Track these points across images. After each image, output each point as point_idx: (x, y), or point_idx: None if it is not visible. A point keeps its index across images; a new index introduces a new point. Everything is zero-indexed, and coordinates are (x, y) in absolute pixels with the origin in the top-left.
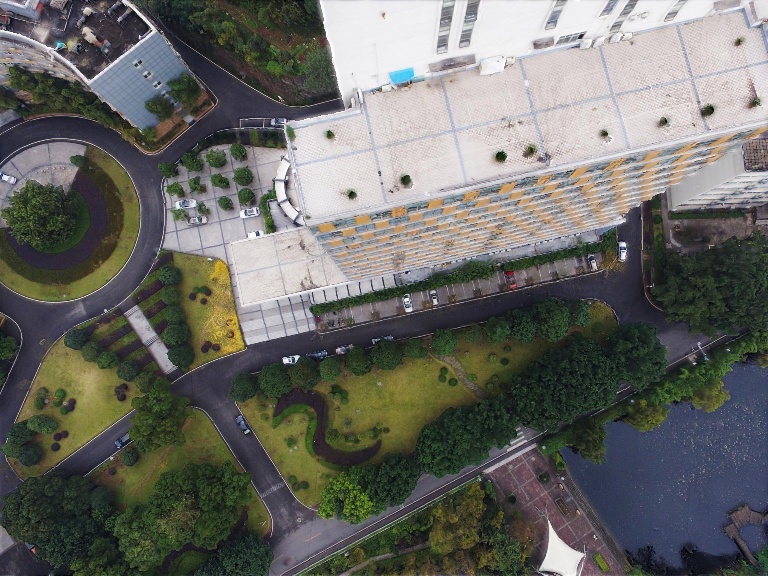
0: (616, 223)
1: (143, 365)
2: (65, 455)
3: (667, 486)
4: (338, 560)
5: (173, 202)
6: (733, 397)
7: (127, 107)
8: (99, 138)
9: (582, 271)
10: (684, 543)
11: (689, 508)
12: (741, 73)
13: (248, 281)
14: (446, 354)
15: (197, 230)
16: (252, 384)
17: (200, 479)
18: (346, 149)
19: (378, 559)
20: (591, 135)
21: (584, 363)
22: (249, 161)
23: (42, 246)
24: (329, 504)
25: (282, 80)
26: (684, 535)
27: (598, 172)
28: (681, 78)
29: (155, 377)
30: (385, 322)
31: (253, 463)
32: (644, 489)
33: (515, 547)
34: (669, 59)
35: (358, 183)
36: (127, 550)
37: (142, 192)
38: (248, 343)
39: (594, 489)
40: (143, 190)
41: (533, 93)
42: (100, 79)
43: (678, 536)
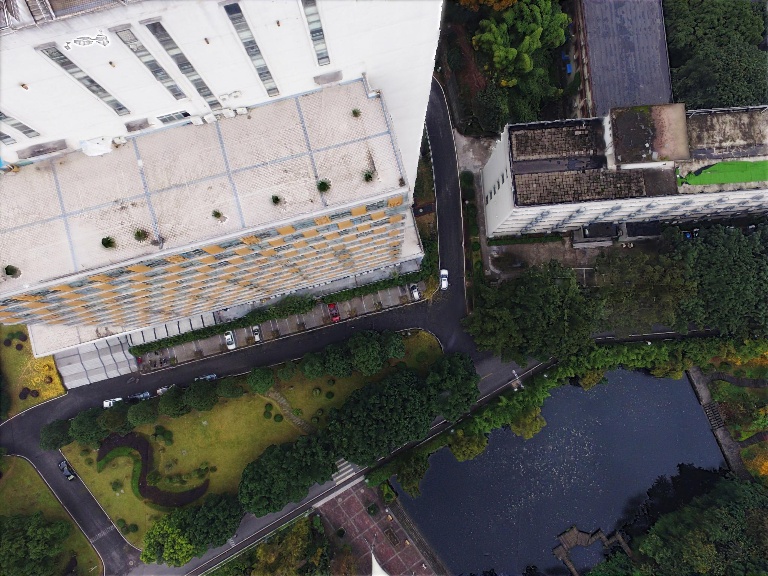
0: (415, 257)
1: None
2: None
3: (497, 511)
4: None
5: None
6: (561, 420)
7: None
8: None
9: (406, 300)
10: (514, 567)
11: (519, 532)
12: (360, 145)
13: (41, 331)
14: (269, 390)
15: None
16: (64, 432)
17: (6, 533)
18: None
19: None
20: (206, 215)
21: (394, 397)
22: None
23: None
24: (149, 549)
25: None
26: (514, 559)
27: (243, 246)
28: (299, 152)
29: None
30: (209, 360)
31: (81, 508)
32: (474, 515)
33: None
34: (287, 133)
35: None
36: None
37: None
38: (69, 387)
39: (425, 518)
40: None
41: (147, 173)
42: None
43: (508, 560)
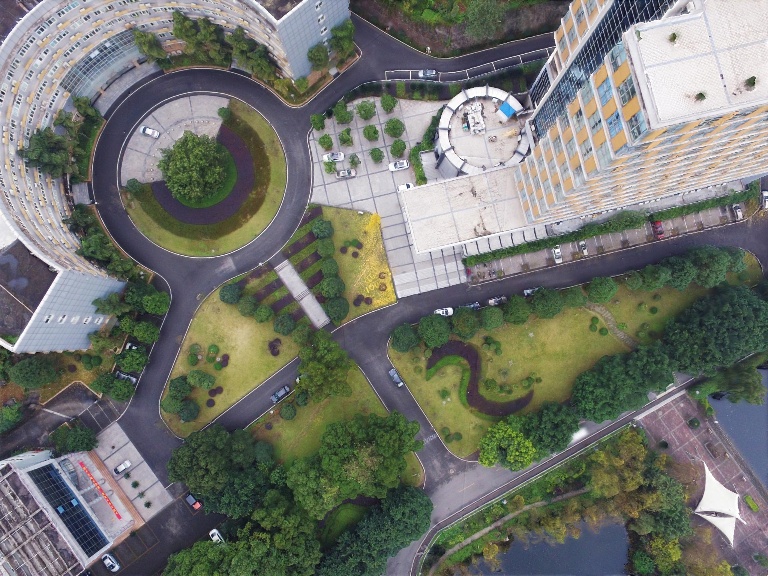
0: None
1: (296, 320)
2: (220, 411)
3: None
4: (496, 508)
5: (320, 156)
6: None
7: (294, 53)
8: (242, 91)
9: (726, 221)
10: None
11: None
12: None
13: (421, 228)
14: (598, 304)
15: (345, 183)
16: None
17: (373, 428)
18: (687, 52)
19: (528, 508)
20: None
21: (745, 306)
22: (395, 114)
23: (194, 199)
24: (492, 452)
25: (435, 29)
26: None
27: None
28: None
29: (312, 331)
30: (535, 273)
31: (405, 416)
32: None
33: (678, 488)
34: None
35: (702, 86)
36: (307, 499)
37: (288, 146)
38: (399, 296)
39: (740, 433)
40: (289, 144)
41: None
42: (287, 19)
43: None
